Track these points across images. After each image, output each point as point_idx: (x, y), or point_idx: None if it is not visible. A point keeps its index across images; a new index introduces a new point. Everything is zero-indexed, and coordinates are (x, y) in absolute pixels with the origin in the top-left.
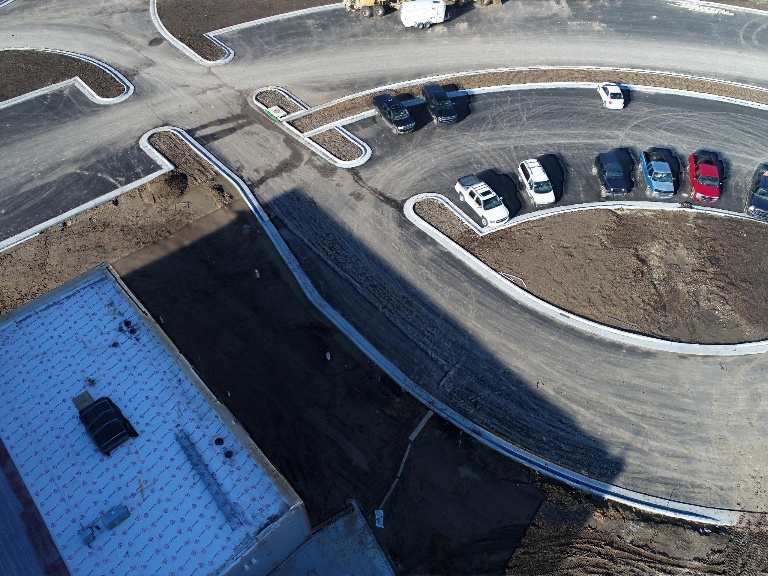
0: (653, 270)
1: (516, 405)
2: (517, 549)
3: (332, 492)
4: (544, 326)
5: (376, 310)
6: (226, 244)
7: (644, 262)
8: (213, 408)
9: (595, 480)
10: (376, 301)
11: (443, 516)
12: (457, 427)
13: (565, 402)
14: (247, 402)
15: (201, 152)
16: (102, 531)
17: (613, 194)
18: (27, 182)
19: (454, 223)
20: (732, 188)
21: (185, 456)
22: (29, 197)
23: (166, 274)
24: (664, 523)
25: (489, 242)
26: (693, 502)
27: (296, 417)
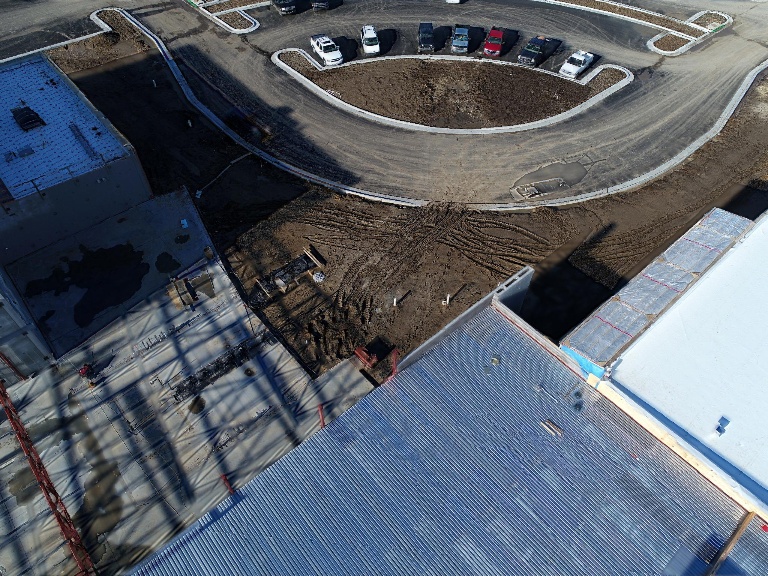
0: (435, 91)
1: (308, 152)
2: (279, 209)
3: (173, 183)
4: (345, 117)
5: (232, 106)
6: (139, 71)
7: (430, 87)
8: (94, 114)
9: (344, 185)
10: (234, 102)
11: (239, 195)
12: (265, 160)
13: (342, 152)
14: (131, 143)
15: (134, 22)
16: (17, 158)
17: (424, 49)
18: (5, 35)
19: (304, 64)
20: (518, 50)
21: (73, 134)
22: (6, 43)
23: (93, 83)
24: (378, 203)
25: (325, 74)
26: (403, 196)
27: (161, 151)
